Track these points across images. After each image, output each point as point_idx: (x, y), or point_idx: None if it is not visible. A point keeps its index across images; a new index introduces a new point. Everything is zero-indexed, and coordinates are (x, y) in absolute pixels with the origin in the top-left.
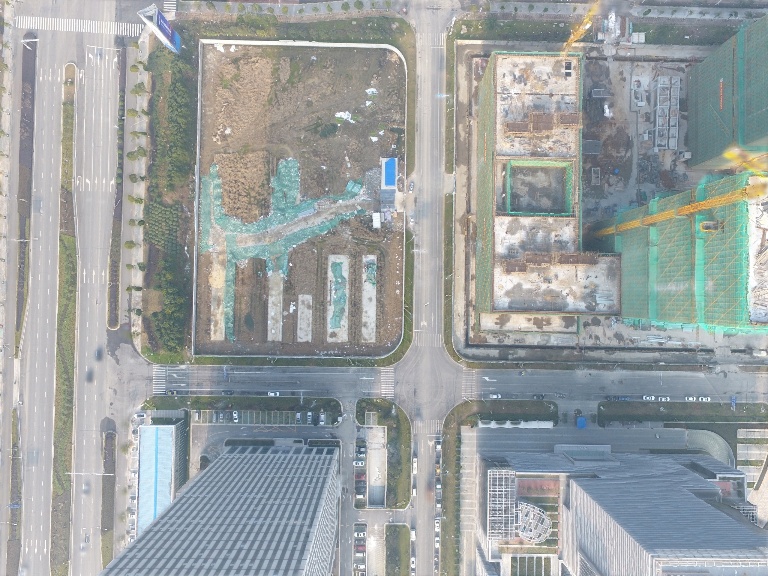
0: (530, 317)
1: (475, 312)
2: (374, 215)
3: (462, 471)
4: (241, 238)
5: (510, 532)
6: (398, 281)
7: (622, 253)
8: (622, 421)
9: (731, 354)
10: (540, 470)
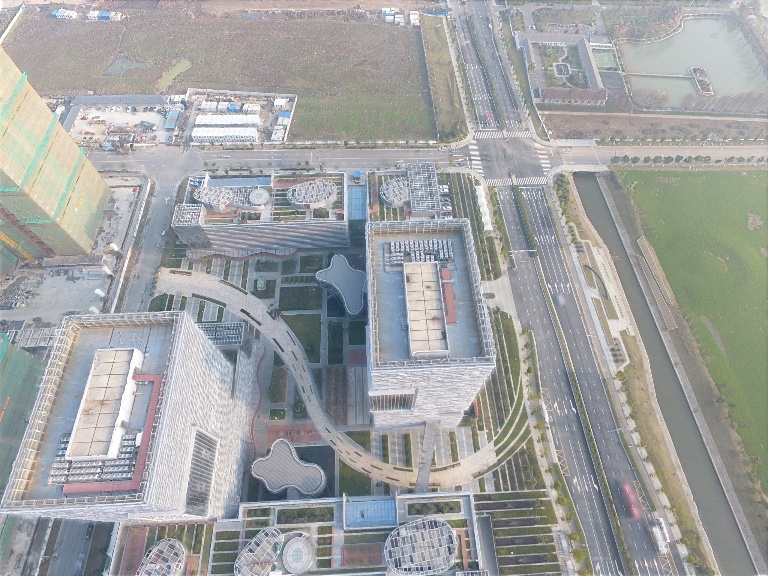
0: None
1: None
2: None
3: None
4: None
5: None
6: None
7: None
8: None
9: None
10: None
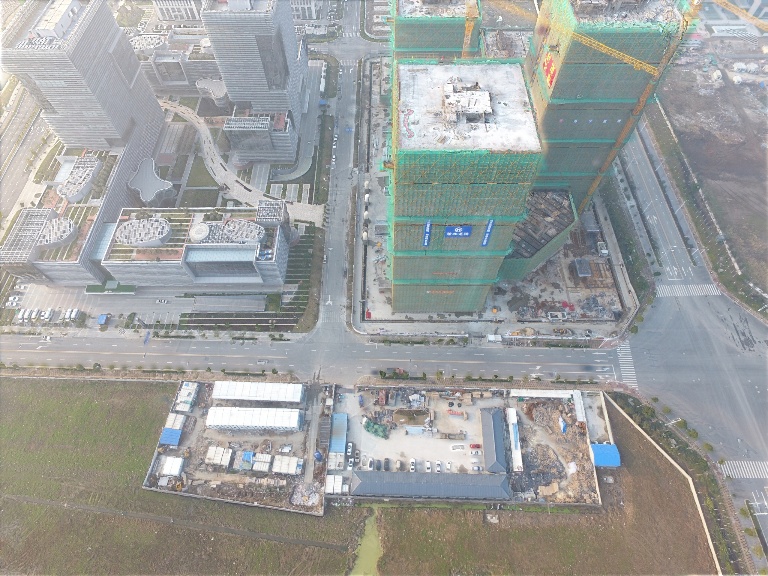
0: None
1: None
2: None
3: None
4: None
5: None
6: None
7: None
8: None
9: None
10: None
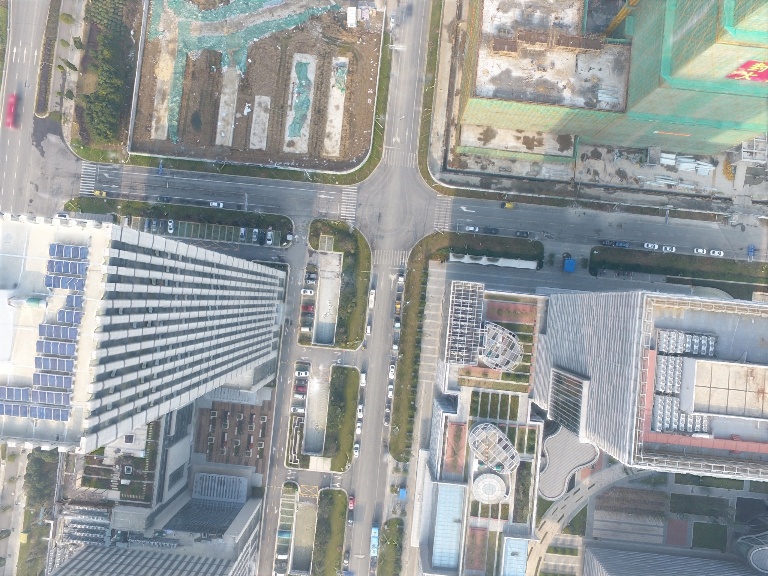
0: (519, 135)
1: (456, 129)
2: (349, 9)
3: (426, 312)
4: (196, 26)
5: (472, 356)
6: (371, 89)
7: (633, 37)
8: (618, 270)
9: (752, 205)
10: (515, 292)
